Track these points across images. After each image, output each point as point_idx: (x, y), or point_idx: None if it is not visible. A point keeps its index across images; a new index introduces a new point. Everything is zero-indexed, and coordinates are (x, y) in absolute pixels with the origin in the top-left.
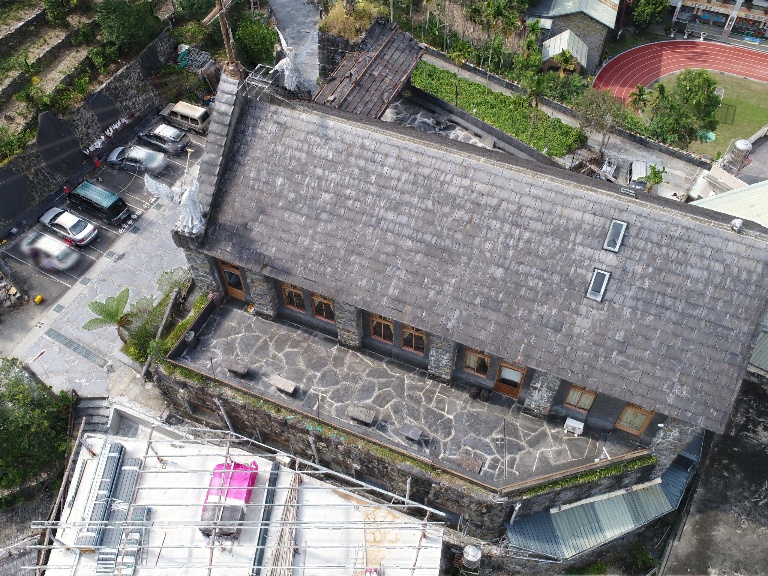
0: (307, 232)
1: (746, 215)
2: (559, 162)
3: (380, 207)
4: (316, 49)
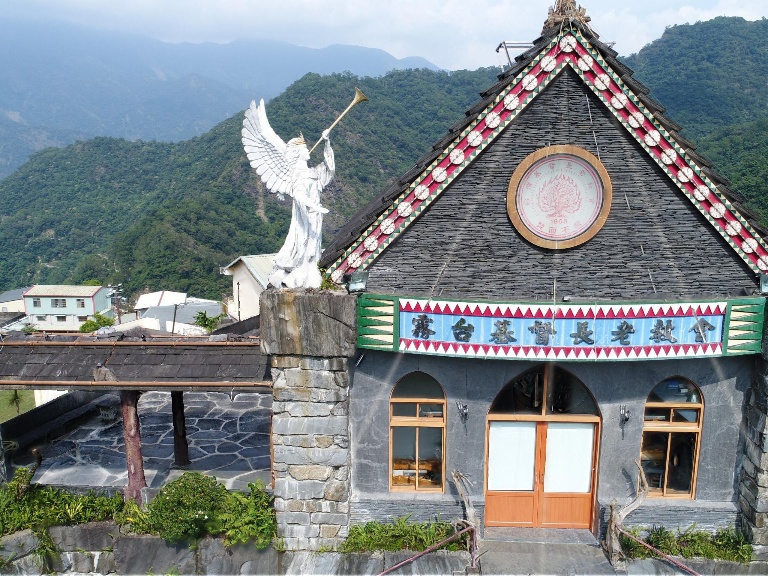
0: None
1: None
2: None
3: None
4: None
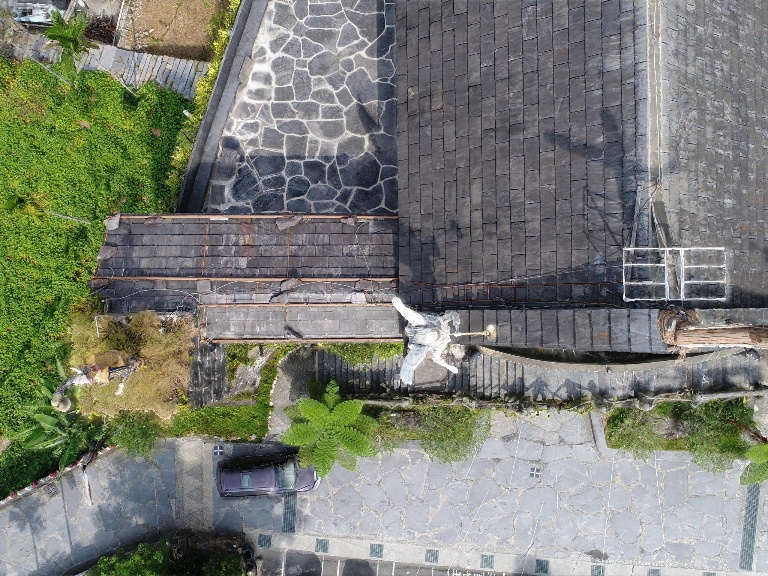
0: (759, 136)
1: None
2: (88, 61)
3: (722, 14)
4: (19, 521)
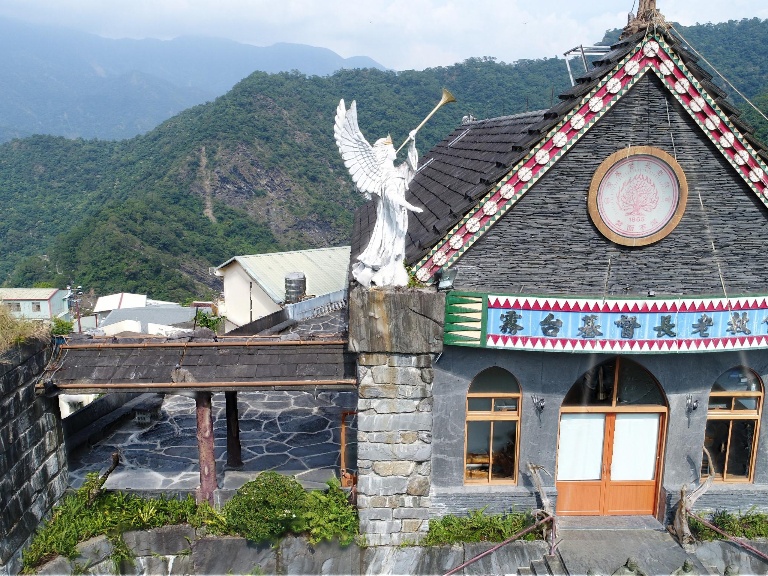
0: None
1: (283, 271)
2: None
3: None
4: None
